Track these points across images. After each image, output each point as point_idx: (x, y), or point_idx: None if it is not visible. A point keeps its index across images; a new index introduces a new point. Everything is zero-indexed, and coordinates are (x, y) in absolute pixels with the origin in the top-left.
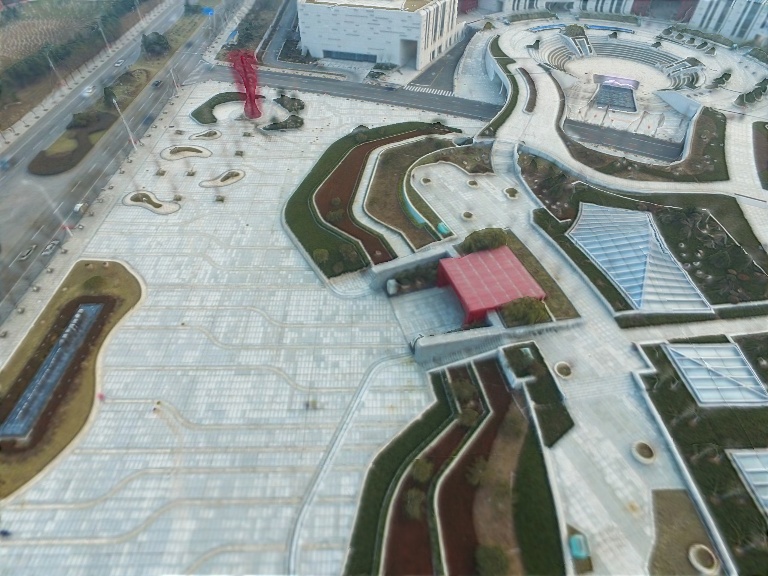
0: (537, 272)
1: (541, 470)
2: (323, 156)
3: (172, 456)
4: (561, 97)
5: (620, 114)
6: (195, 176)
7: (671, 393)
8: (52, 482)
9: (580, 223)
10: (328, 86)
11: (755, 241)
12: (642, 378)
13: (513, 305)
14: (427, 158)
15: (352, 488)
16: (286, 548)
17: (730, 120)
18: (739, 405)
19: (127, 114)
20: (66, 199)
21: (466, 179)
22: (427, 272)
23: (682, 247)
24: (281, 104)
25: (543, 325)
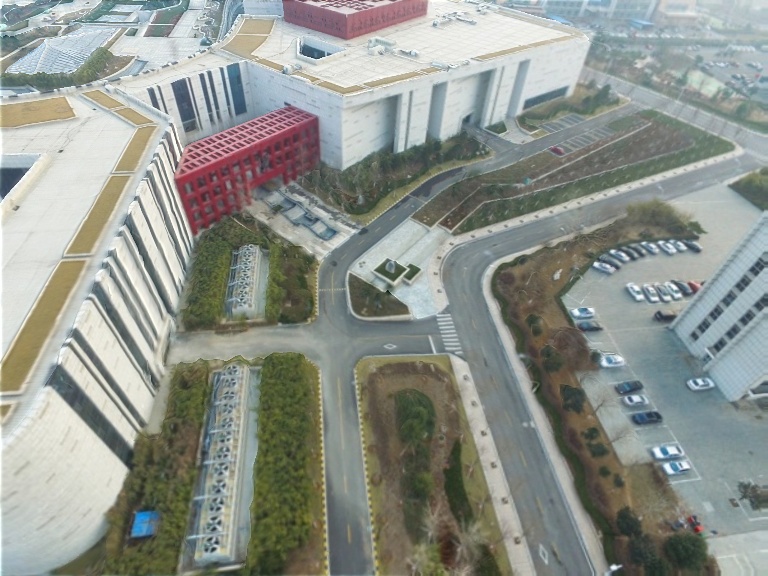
0: None
1: None
2: None
3: None
4: None
5: None
6: None
7: None
8: None
9: None
10: None
11: None
12: None
13: None
14: None
15: None
16: None
17: None
18: None
19: None
20: None
21: None
22: None
23: None
24: None
25: None
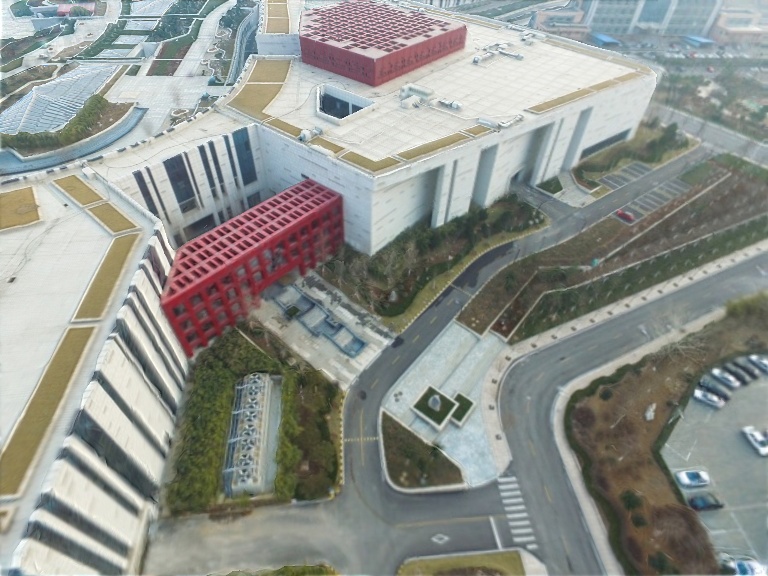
0: (102, 9)
1: None
2: None
3: None
4: None
5: None
6: None
7: (116, 27)
8: None
9: (141, 1)
10: None
11: None
12: (108, 24)
13: None
14: None
15: None
16: None
17: None
18: None
19: None
20: None
21: None
22: None
23: (176, 5)
24: None
25: (86, 17)
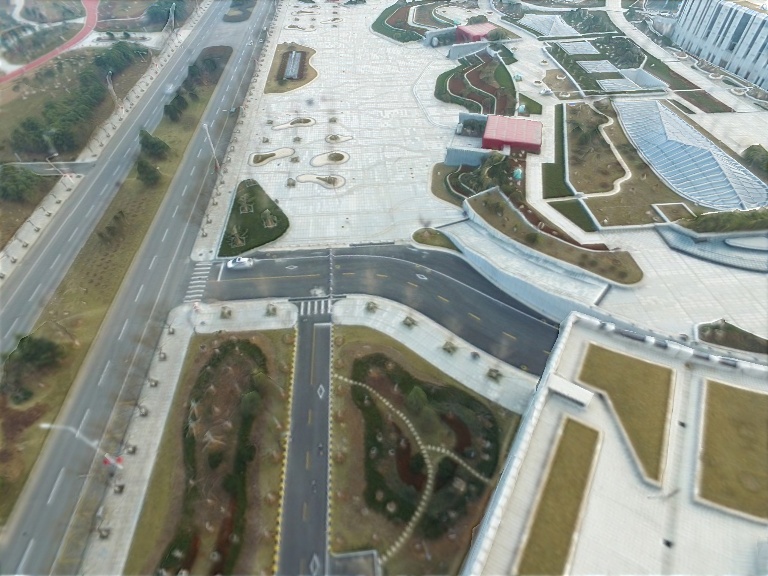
0: None
1: (505, 69)
2: (383, 12)
3: None
4: None
5: None
6: (316, 20)
7: None
8: None
9: (524, 18)
10: None
11: None
12: (546, 48)
13: None
14: (443, 6)
15: None
16: (411, 92)
17: None
18: None
19: (260, 2)
20: (254, 29)
21: (465, 11)
22: (451, 36)
23: (573, 22)
24: None
25: (505, 40)
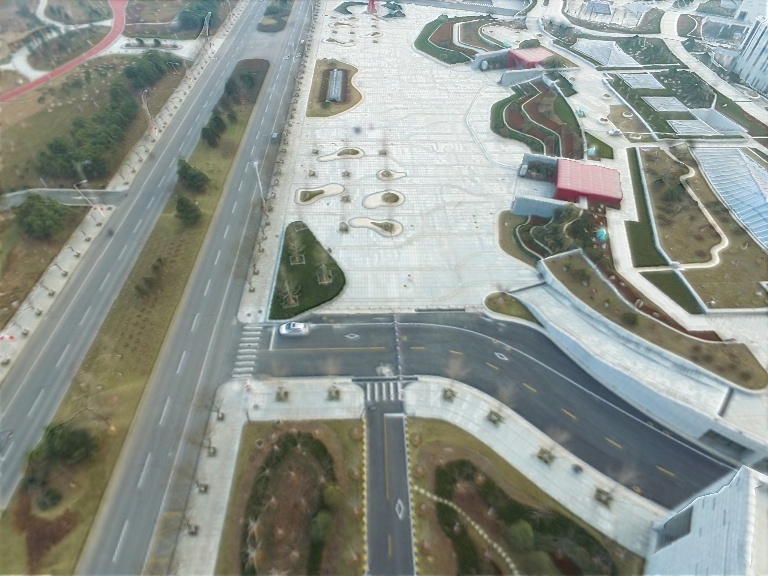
0: None
1: (564, 102)
2: (425, 28)
3: (405, 105)
4: (564, 0)
5: (601, 16)
6: (355, 34)
7: (620, 84)
8: (360, 109)
9: (578, 44)
10: (411, 1)
11: (669, 50)
12: (607, 80)
13: (548, 58)
14: (488, 25)
15: (486, 111)
16: (464, 122)
17: (667, 13)
18: (649, 88)
19: (295, 10)
20: (290, 40)
21: (513, 31)
22: (501, 59)
23: (630, 50)
24: (387, 7)
25: (562, 68)
